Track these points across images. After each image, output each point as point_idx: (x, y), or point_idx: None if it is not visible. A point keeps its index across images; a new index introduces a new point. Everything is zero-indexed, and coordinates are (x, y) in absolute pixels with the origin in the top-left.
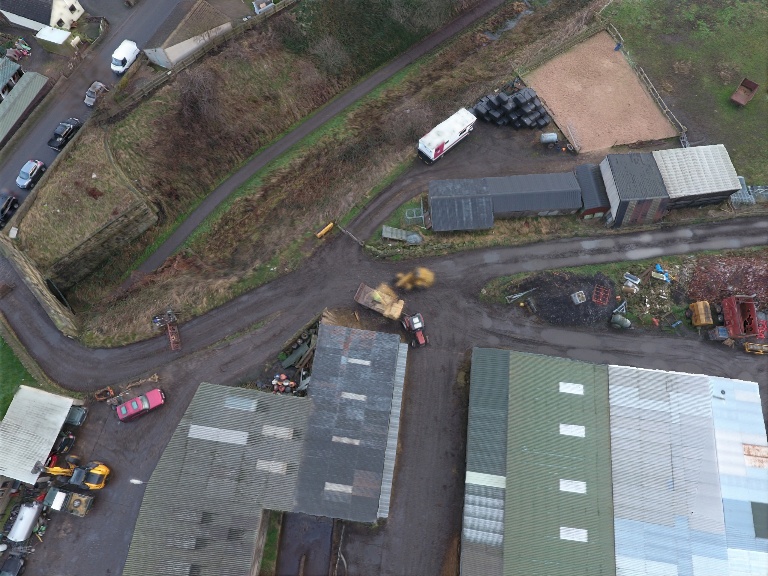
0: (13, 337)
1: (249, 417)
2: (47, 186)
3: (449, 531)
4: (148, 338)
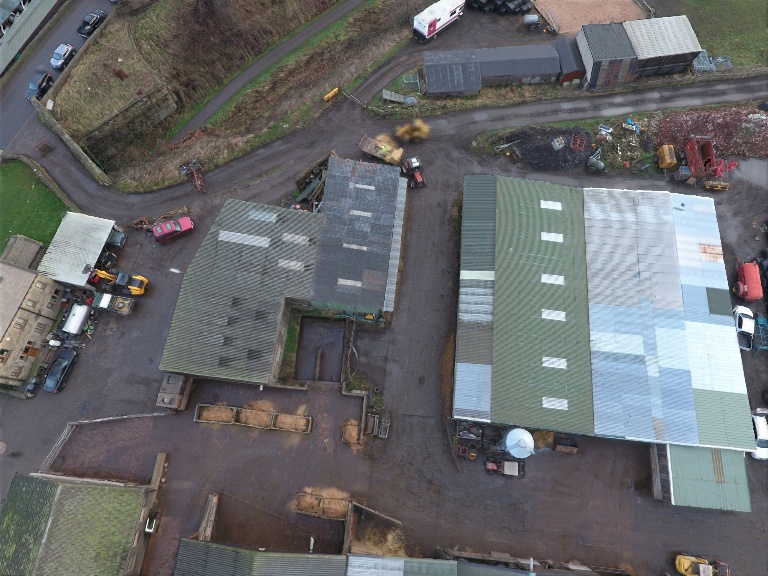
0: (55, 186)
1: (270, 226)
2: (78, 66)
3: (446, 330)
4: (176, 184)
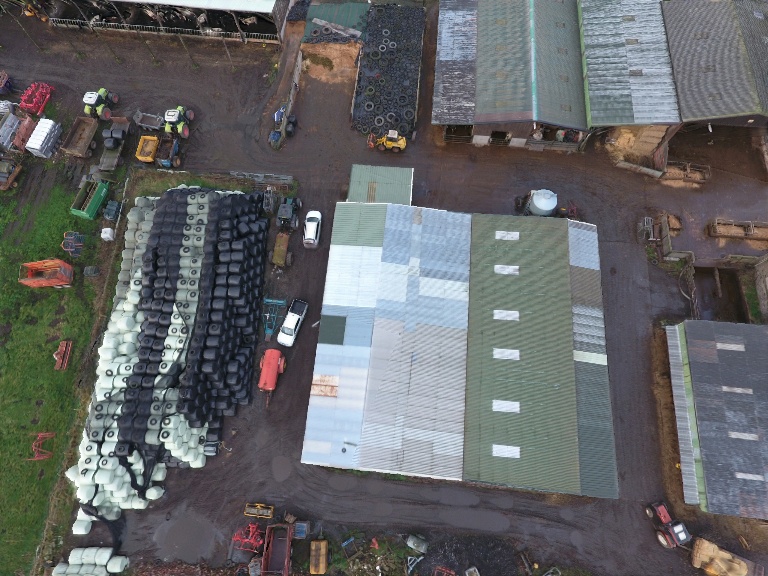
0: None
1: None
2: None
3: None
4: None
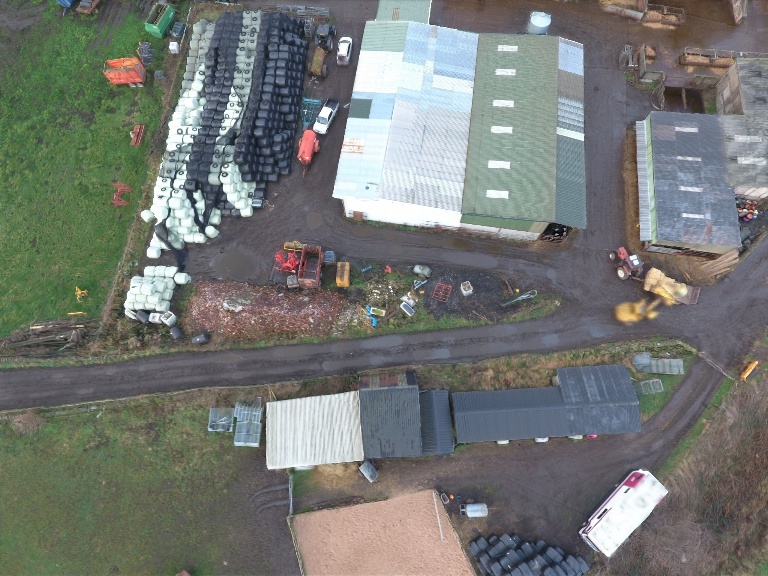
0: None
1: None
2: None
3: None
4: None
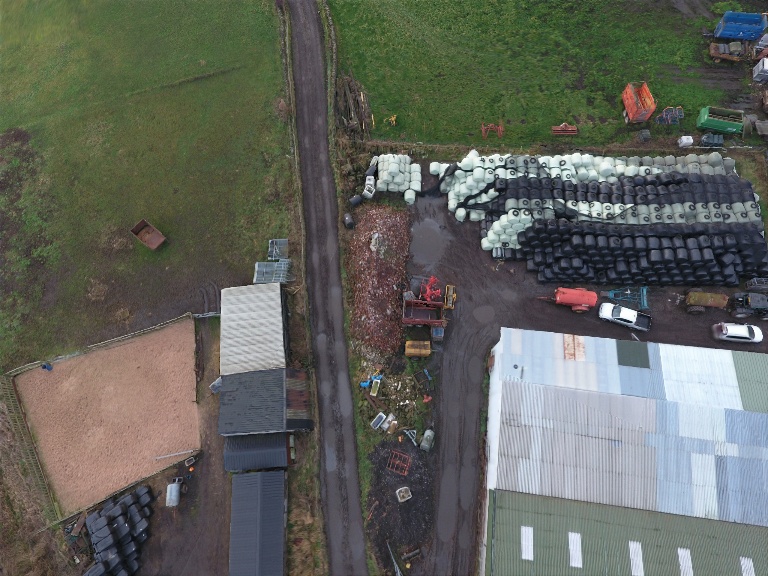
0: None
1: None
2: None
3: None
4: None
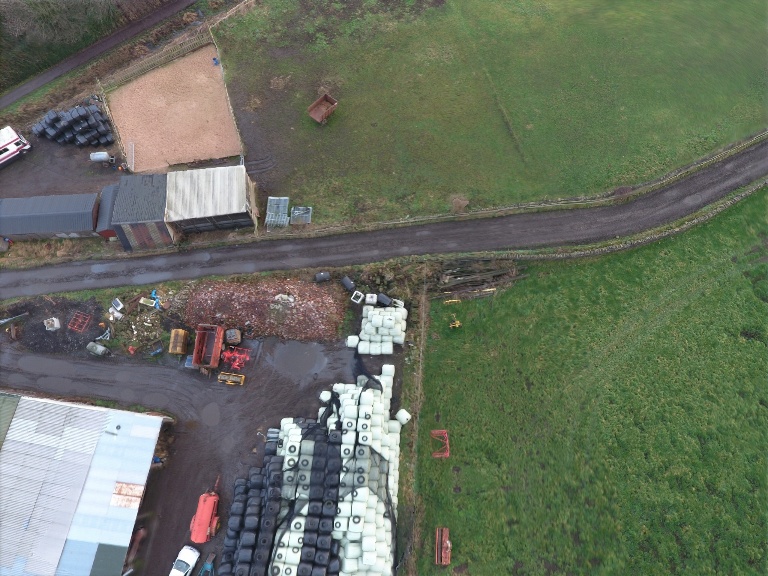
0: None
1: None
2: None
3: None
4: None
